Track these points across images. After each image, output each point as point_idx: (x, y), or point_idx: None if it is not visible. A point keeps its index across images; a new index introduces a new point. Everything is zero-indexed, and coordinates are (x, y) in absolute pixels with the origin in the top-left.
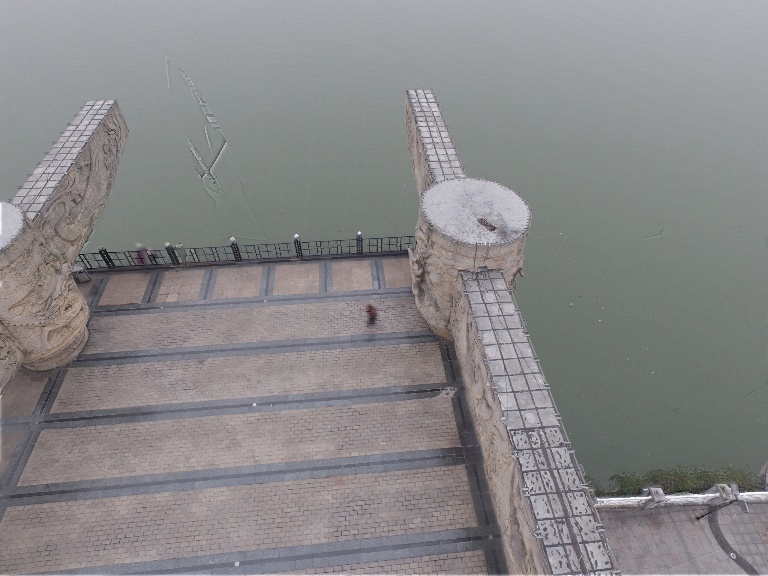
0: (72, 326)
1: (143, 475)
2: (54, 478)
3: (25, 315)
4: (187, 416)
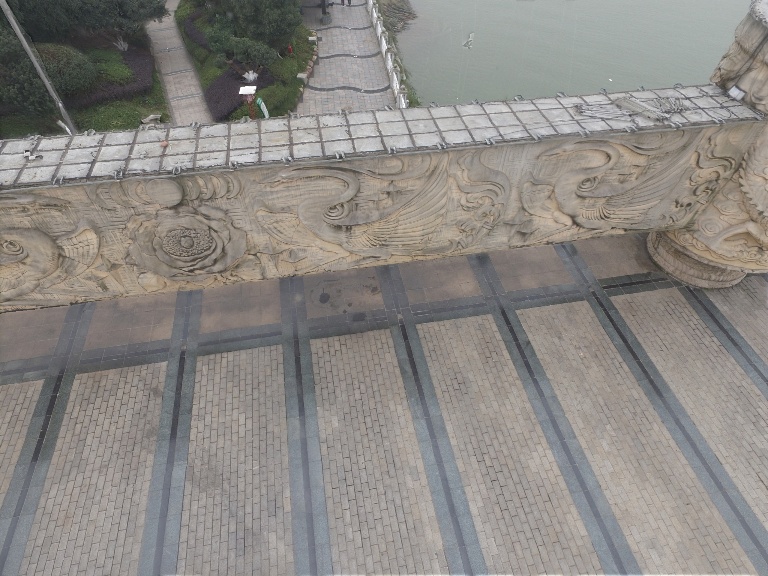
0: (764, 255)
1: (593, 471)
2: (539, 346)
3: (767, 187)
4: (720, 506)
